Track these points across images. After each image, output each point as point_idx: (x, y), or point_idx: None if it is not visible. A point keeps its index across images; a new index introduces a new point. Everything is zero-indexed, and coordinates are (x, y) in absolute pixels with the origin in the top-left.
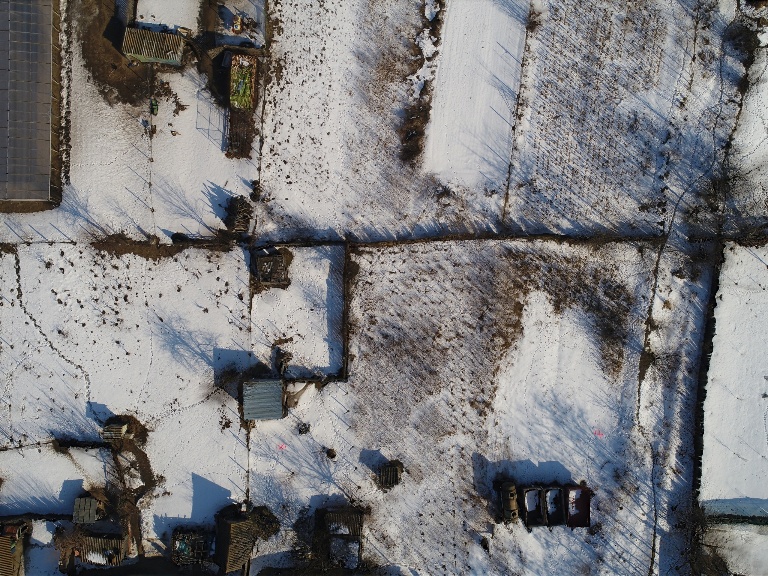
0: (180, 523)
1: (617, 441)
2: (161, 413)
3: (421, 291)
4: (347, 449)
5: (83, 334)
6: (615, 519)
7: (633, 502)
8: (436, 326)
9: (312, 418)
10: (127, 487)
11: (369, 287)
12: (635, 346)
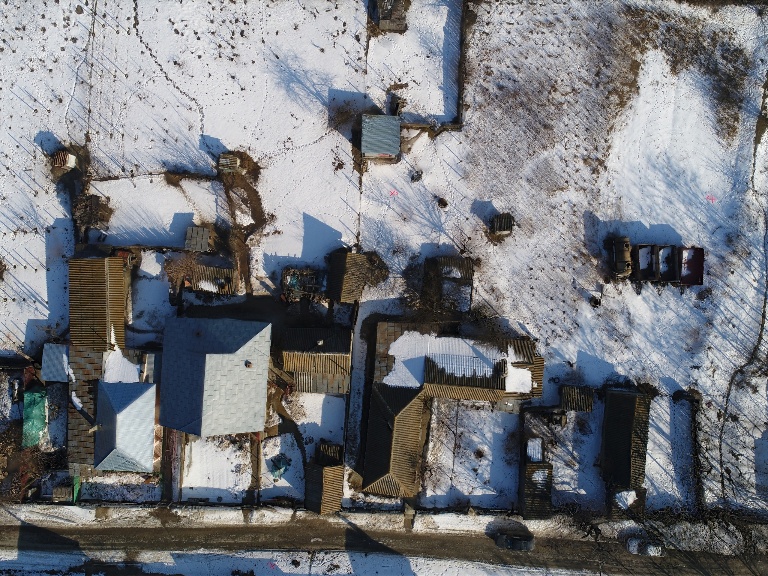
0: (290, 262)
1: (730, 206)
2: (274, 151)
3: (538, 44)
4: (459, 199)
5: (199, 66)
6: (726, 283)
7: (745, 267)
8: (552, 80)
9: (424, 166)
10: (238, 223)
11: (486, 37)
12: (752, 110)
